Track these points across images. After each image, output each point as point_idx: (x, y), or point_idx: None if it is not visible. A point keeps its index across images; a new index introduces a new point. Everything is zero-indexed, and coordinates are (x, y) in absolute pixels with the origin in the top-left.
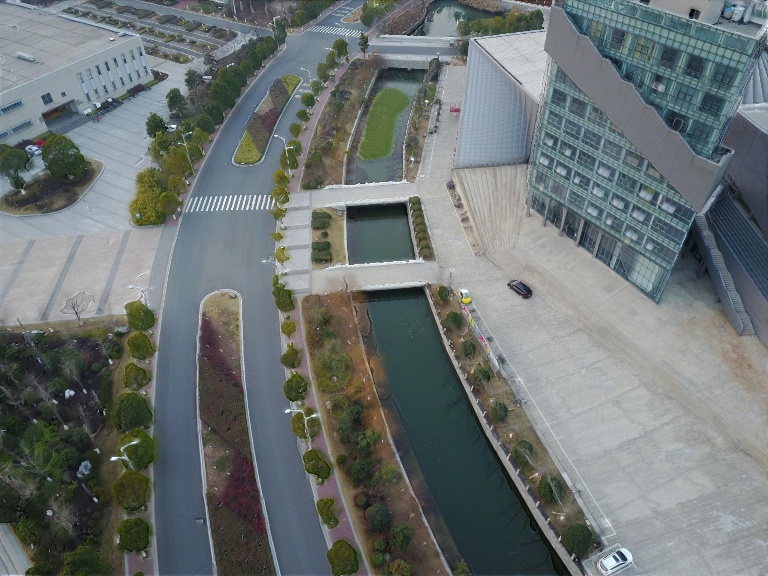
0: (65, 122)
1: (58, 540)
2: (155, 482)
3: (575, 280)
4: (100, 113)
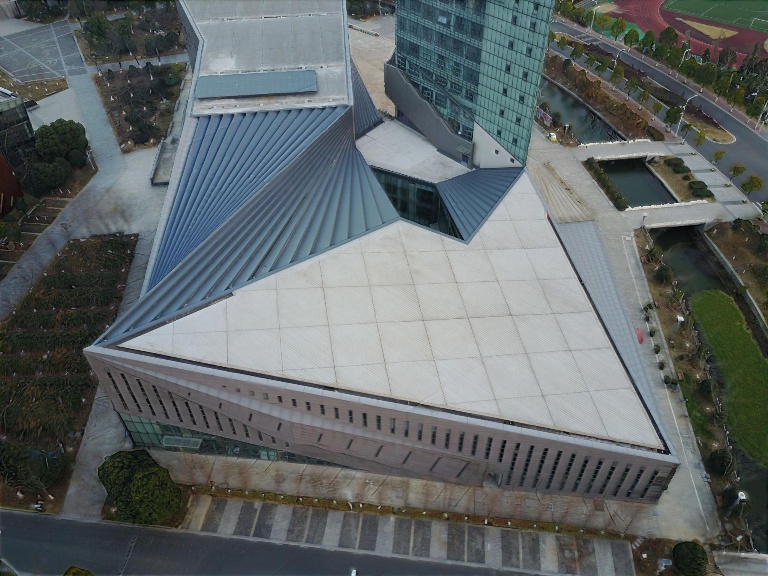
0: None
1: None
2: (674, 80)
3: None
4: None
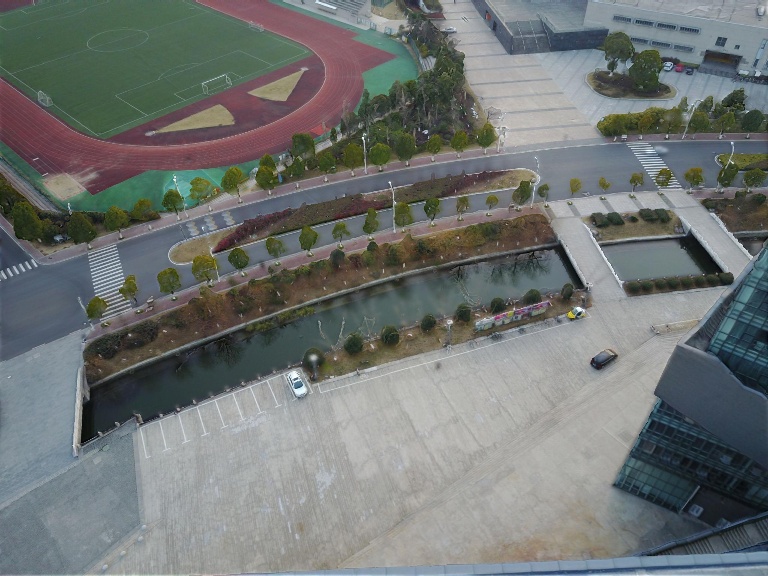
0: (718, 68)
1: (330, 147)
2: (370, 177)
3: (629, 403)
4: (747, 79)
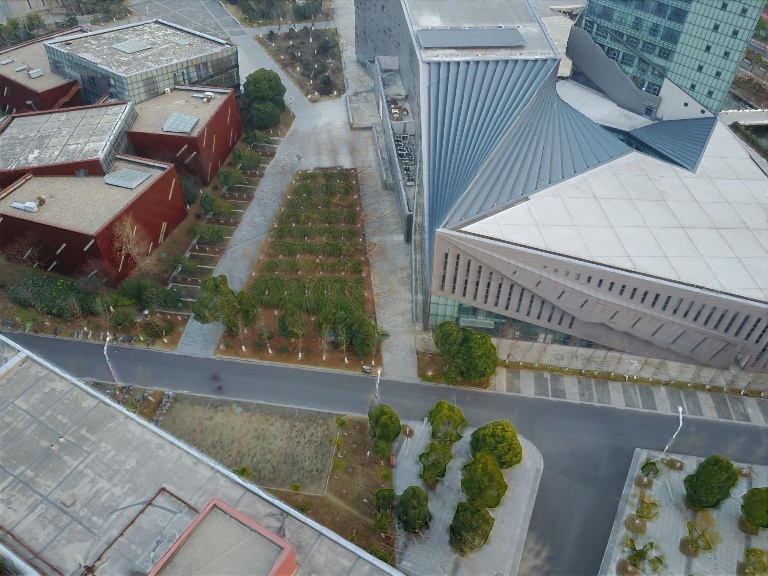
0: None
1: None
2: None
3: None
4: None
